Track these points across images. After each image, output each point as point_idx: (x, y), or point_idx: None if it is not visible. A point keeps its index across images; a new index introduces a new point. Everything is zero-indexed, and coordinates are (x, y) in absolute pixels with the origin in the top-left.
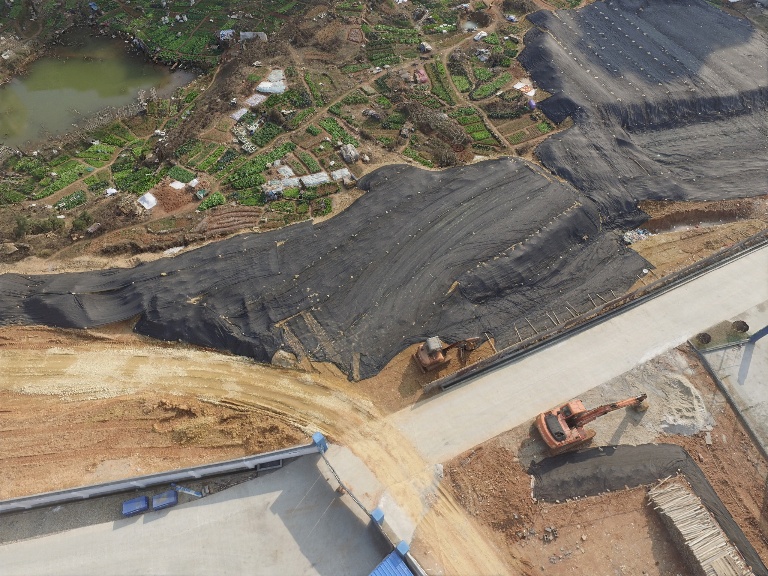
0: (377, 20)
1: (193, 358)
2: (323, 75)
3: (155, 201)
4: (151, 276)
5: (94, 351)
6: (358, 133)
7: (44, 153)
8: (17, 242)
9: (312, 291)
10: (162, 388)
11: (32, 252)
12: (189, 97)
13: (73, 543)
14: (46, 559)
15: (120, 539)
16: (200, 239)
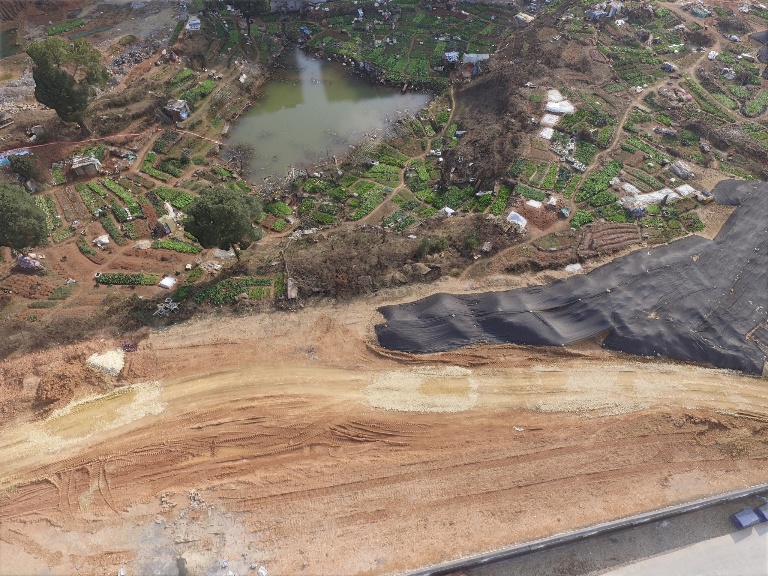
0: (610, 41)
1: (680, 372)
2: (594, 95)
3: (525, 219)
4: (595, 293)
5: (578, 368)
6: (665, 150)
7: (325, 174)
8: (421, 262)
9: (755, 304)
10: (672, 402)
11: (443, 272)
12: (443, 117)
13: (706, 557)
14: (691, 574)
15: (748, 551)
16: (594, 256)
